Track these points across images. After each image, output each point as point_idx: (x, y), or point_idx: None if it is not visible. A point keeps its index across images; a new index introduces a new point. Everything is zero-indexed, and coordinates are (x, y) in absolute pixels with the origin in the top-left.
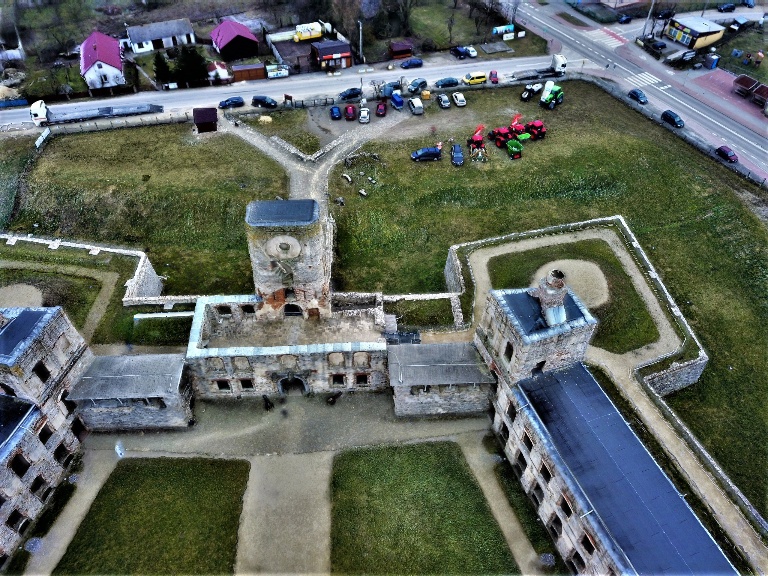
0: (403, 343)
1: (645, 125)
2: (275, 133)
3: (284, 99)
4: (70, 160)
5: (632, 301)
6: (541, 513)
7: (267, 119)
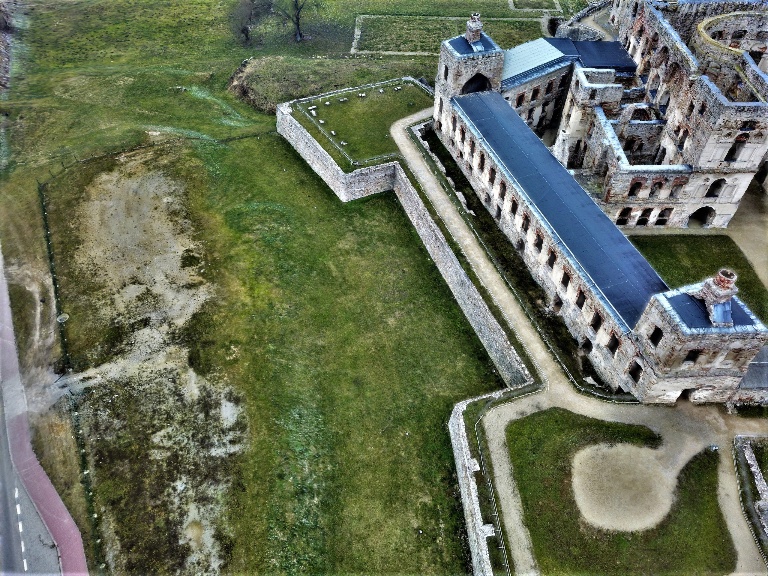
0: None
1: None
2: None
3: None
4: None
5: (532, 475)
6: None
7: None
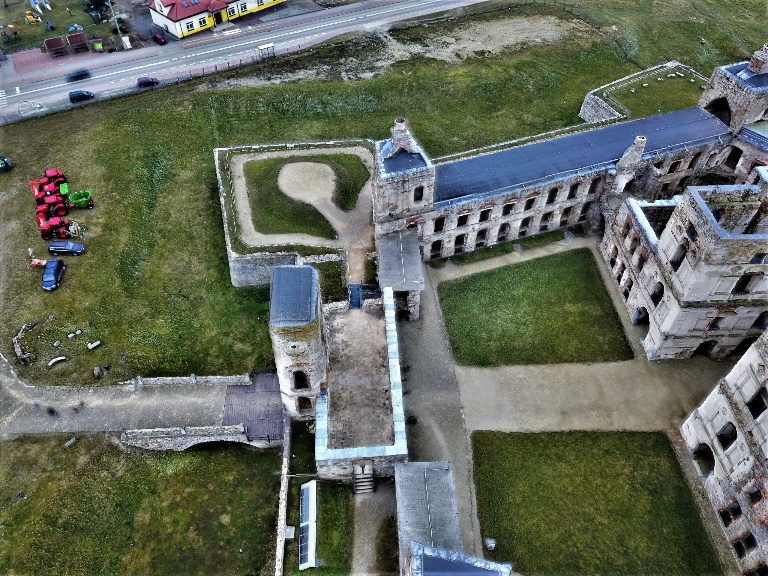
0: (360, 295)
1: (78, 114)
2: None
3: None
4: None
5: None
6: (490, 242)
7: None
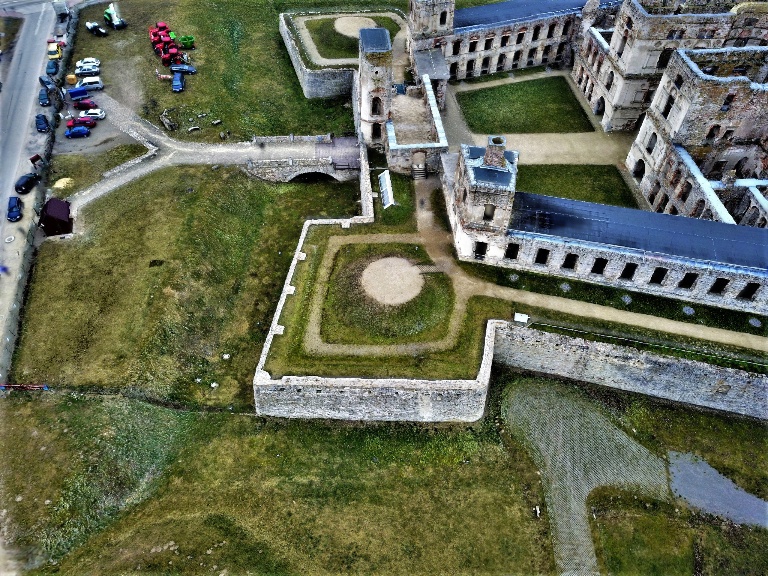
0: (403, 89)
1: None
2: (97, 174)
3: (32, 165)
4: (89, 348)
5: None
6: (492, 70)
7: (65, 180)
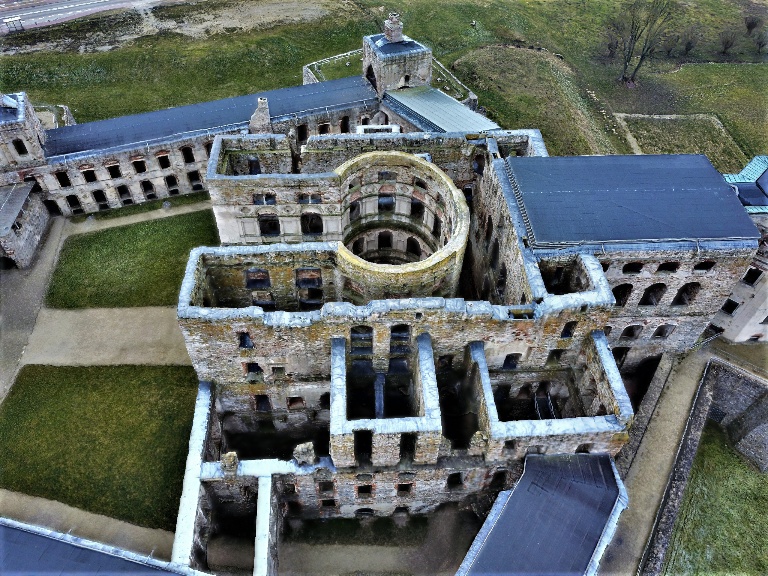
0: None
1: None
2: None
3: None
4: None
5: None
6: (137, 199)
7: None
